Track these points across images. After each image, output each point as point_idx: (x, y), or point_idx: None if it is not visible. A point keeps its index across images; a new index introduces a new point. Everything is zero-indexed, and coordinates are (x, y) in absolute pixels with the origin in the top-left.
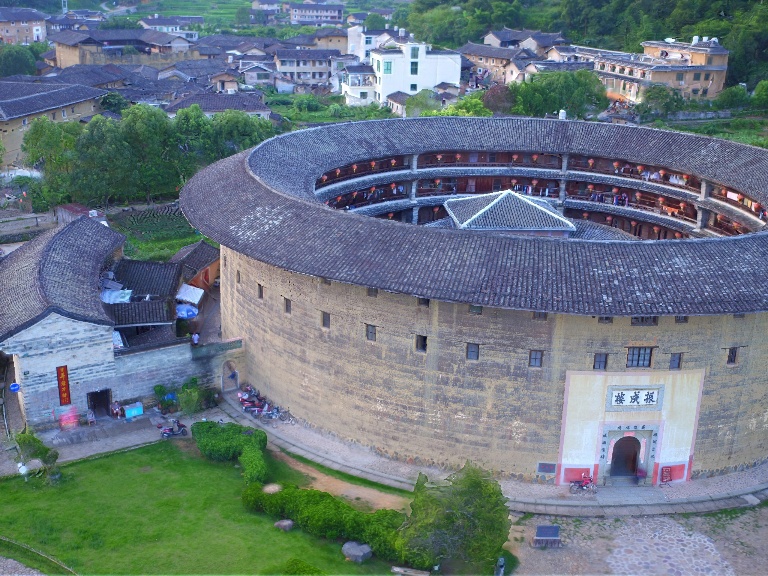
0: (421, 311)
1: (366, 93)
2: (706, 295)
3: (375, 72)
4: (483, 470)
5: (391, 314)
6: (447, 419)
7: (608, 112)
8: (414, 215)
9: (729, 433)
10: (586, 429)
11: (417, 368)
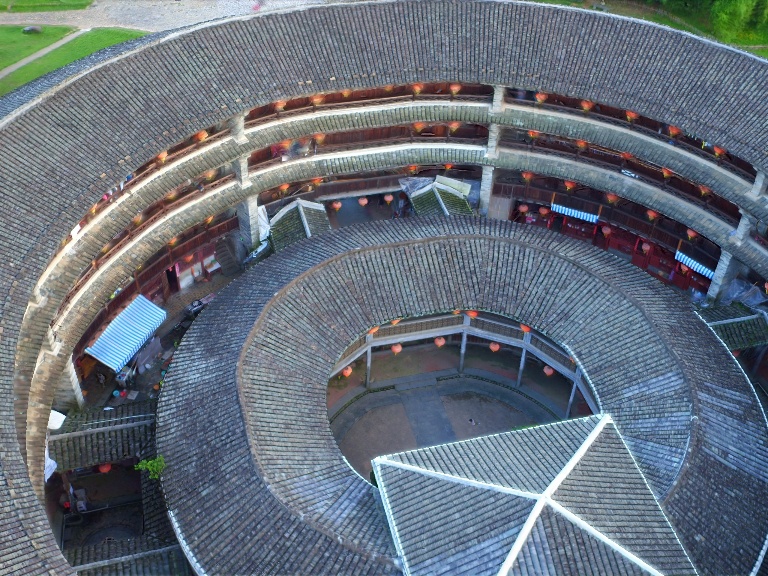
0: None
1: None
2: None
3: None
4: None
5: None
6: None
7: None
8: None
9: None
10: None
11: None
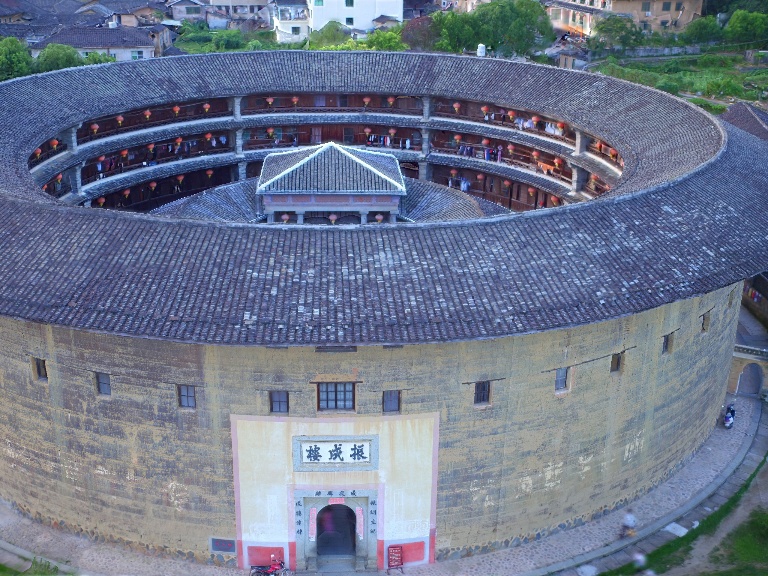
0: (32, 325)
1: (298, 28)
2: (405, 312)
3: (308, 4)
4: (59, 572)
5: (0, 327)
6: (86, 474)
7: (558, 48)
8: (240, 172)
9: (489, 498)
10: (269, 495)
11: (41, 403)
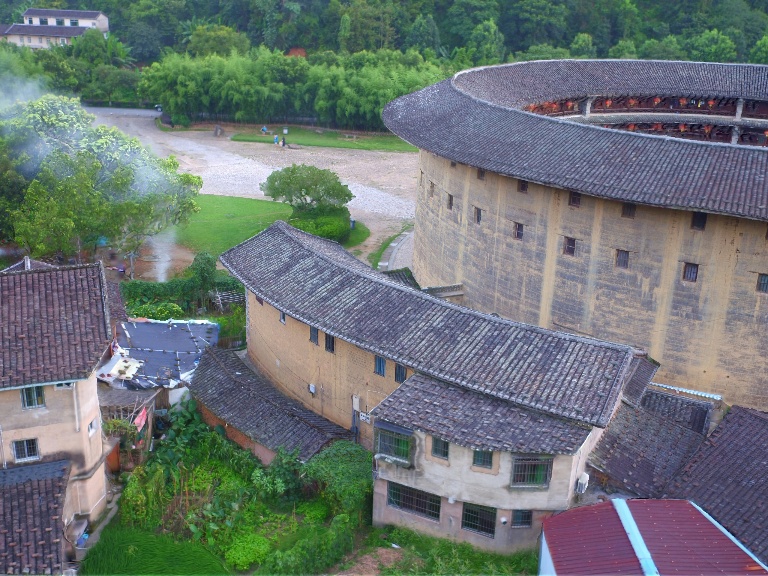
0: None
1: None
2: None
3: None
4: None
5: None
6: None
7: None
8: None
9: None
10: None
11: None
